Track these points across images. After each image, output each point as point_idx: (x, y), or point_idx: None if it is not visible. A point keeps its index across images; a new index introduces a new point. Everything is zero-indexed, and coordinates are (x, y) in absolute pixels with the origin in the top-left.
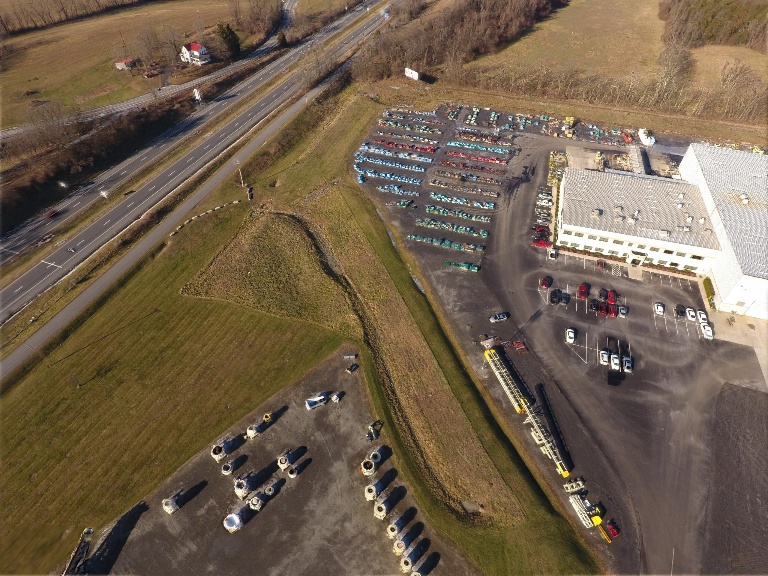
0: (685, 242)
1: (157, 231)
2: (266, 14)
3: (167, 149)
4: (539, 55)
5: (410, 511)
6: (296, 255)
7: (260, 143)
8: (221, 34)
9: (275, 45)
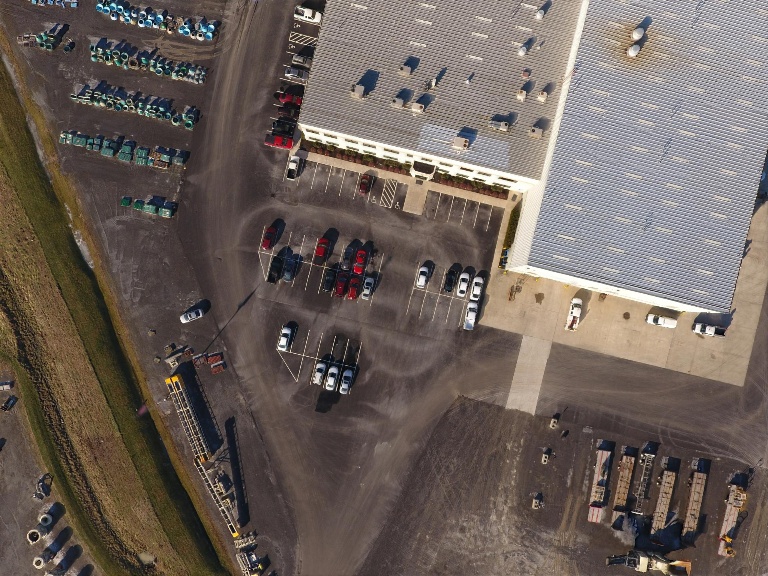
0: (489, 161)
1: None
2: None
3: None
4: None
5: (87, 568)
6: None
7: None
8: None
9: None
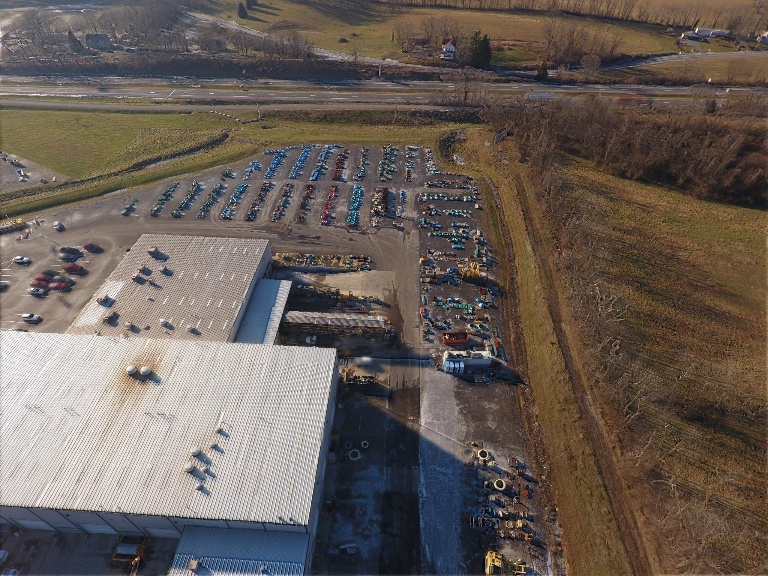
0: (84, 315)
1: (202, 107)
2: (592, 50)
3: (304, 86)
4: (760, 242)
5: None
6: None
7: (319, 107)
8: (474, 41)
9: (534, 74)
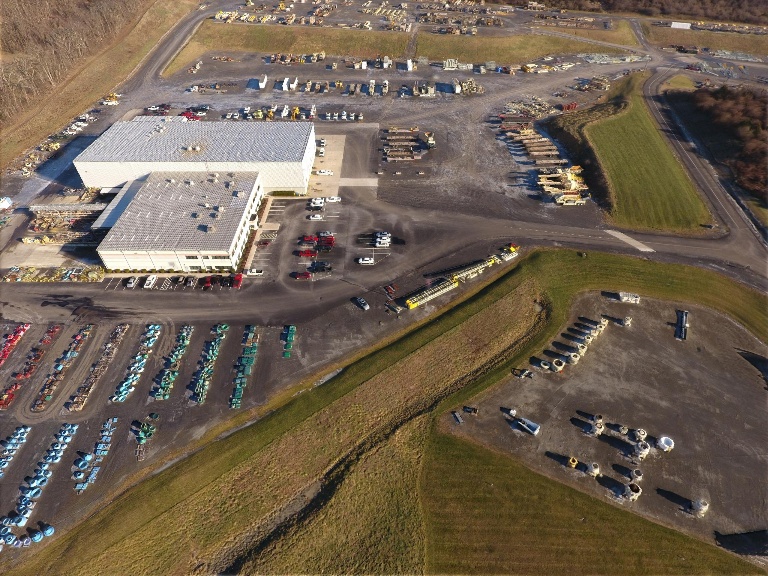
0: (250, 186)
1: None
2: None
3: None
4: None
5: (565, 337)
6: (290, 575)
7: None
8: None
9: None
